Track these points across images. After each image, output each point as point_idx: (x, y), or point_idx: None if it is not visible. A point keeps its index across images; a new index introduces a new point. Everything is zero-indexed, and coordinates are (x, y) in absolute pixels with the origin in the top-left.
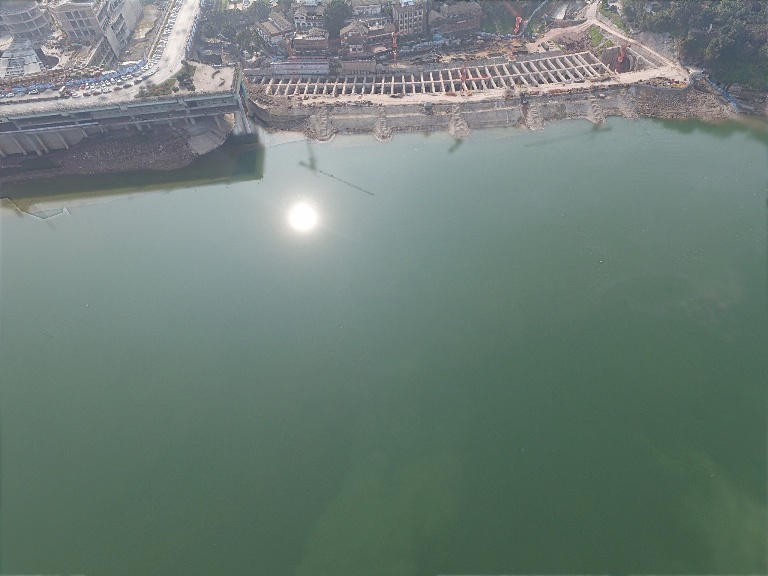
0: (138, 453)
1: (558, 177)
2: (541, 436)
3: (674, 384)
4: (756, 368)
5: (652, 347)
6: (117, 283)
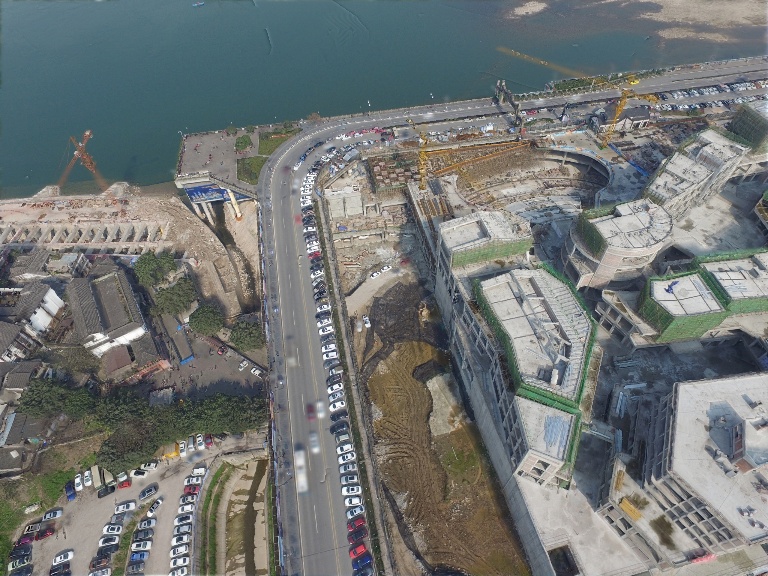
0: (259, 39)
1: None
2: None
3: (1, 57)
4: None
5: None
6: (273, 49)
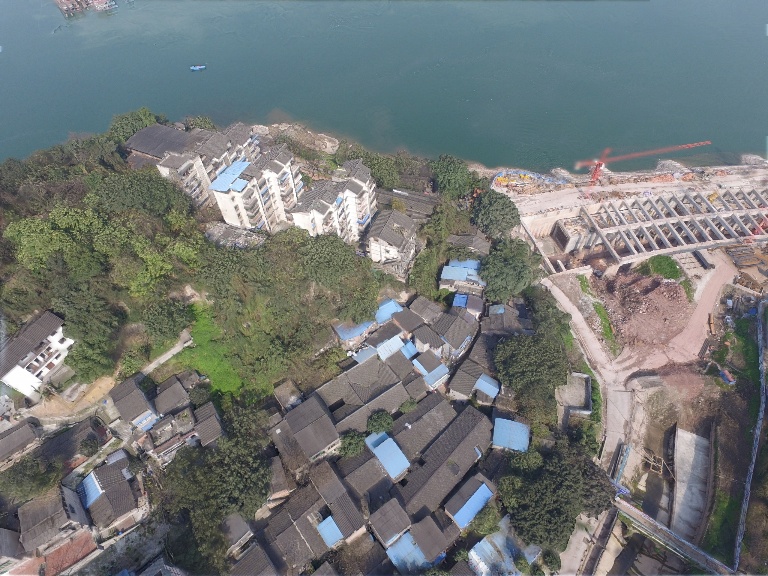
0: None
1: (637, 114)
2: (629, 24)
3: None
4: (535, 29)
5: (581, 35)
6: None
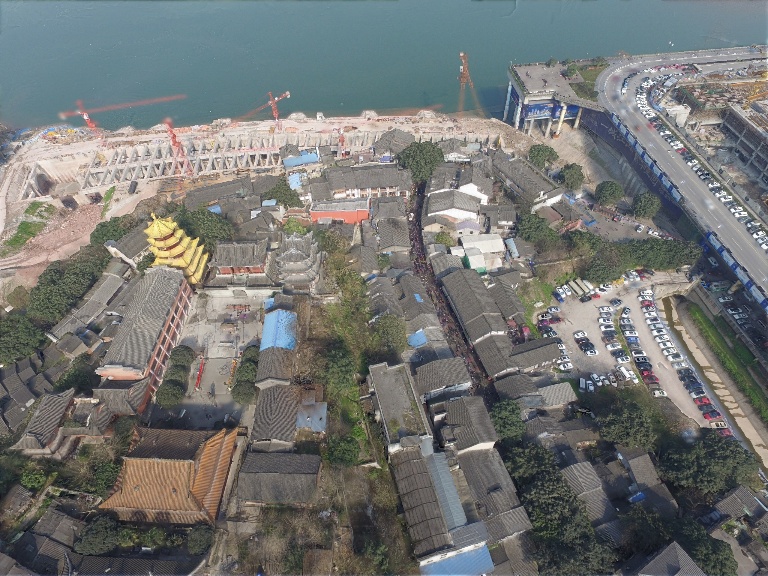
0: (476, 6)
1: (240, 83)
2: None
3: None
4: (224, 15)
5: (259, 19)
6: (516, 10)
